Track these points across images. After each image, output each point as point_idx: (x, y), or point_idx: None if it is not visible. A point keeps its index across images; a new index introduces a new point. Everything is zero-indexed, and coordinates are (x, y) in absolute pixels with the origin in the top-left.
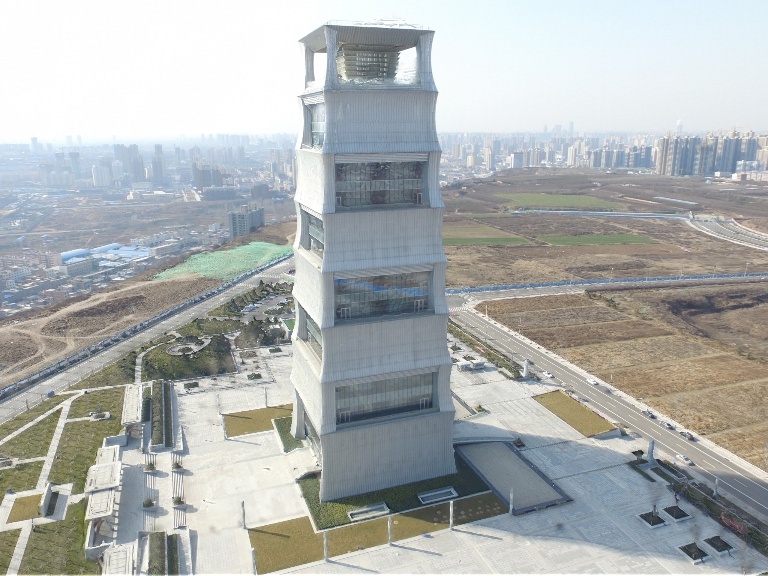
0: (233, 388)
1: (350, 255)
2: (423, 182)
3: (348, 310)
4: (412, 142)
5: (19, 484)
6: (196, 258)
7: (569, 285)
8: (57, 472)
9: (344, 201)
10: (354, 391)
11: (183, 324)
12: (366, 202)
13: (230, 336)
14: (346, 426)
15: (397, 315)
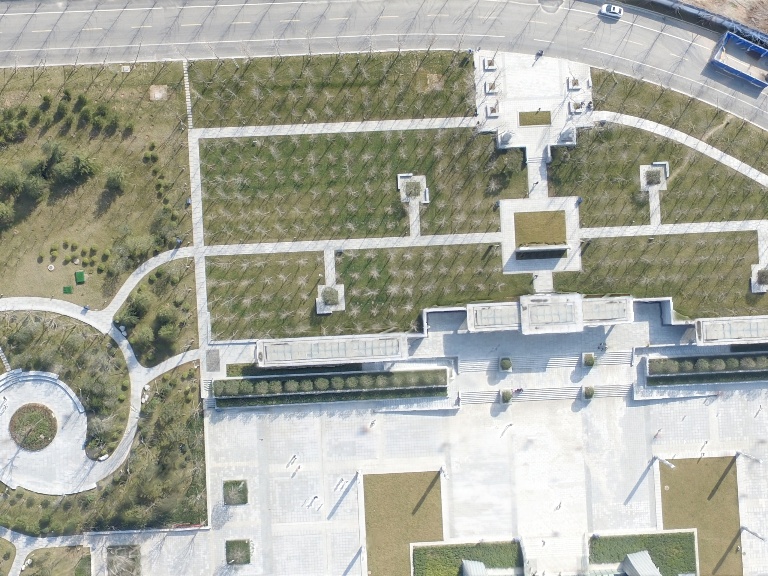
0: None
1: None
2: None
3: None
4: None
5: (597, 206)
6: None
7: None
8: (613, 246)
9: None
10: None
11: None
12: None
13: None
14: None
15: None
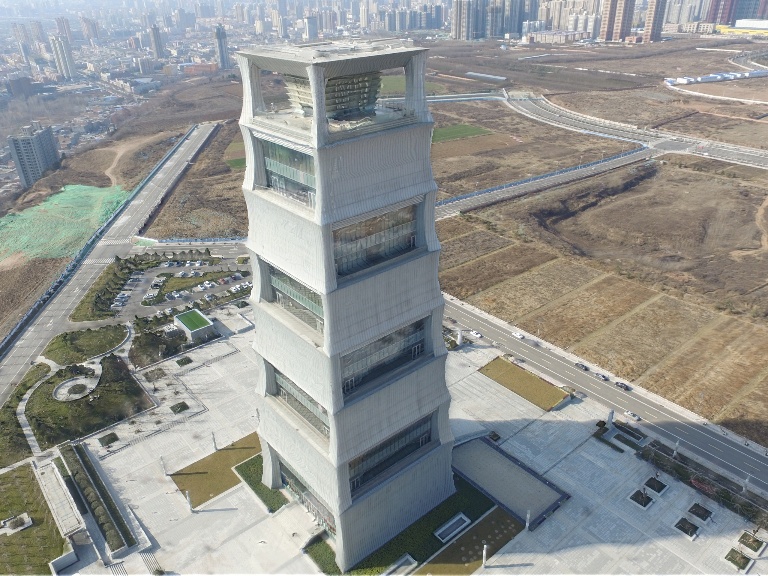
0: (162, 431)
1: (355, 328)
2: (417, 223)
3: (351, 381)
4: (410, 186)
5: None
6: (5, 225)
7: (441, 206)
8: None
9: (341, 268)
10: (363, 457)
11: (47, 342)
12: (365, 263)
13: (121, 352)
14: (360, 495)
15: (399, 369)
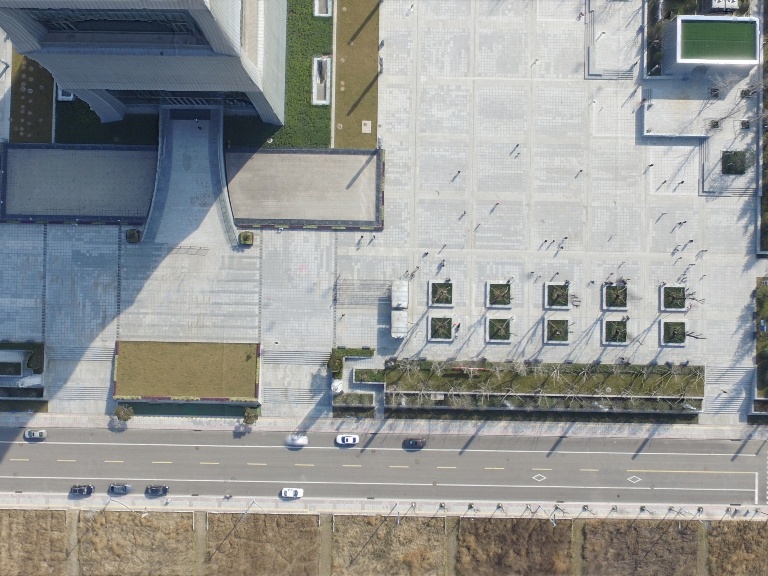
0: None
1: None
2: None
3: None
4: None
5: None
6: None
7: None
8: None
9: None
10: None
11: None
12: None
13: None
14: None
15: None
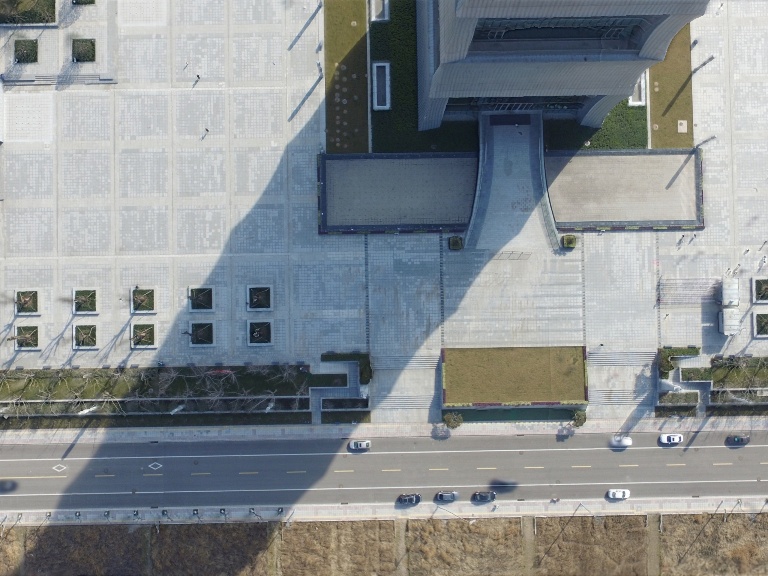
0: None
1: None
2: None
3: None
4: None
5: None
6: None
7: None
8: None
9: None
10: None
11: None
12: None
13: None
14: None
15: None
